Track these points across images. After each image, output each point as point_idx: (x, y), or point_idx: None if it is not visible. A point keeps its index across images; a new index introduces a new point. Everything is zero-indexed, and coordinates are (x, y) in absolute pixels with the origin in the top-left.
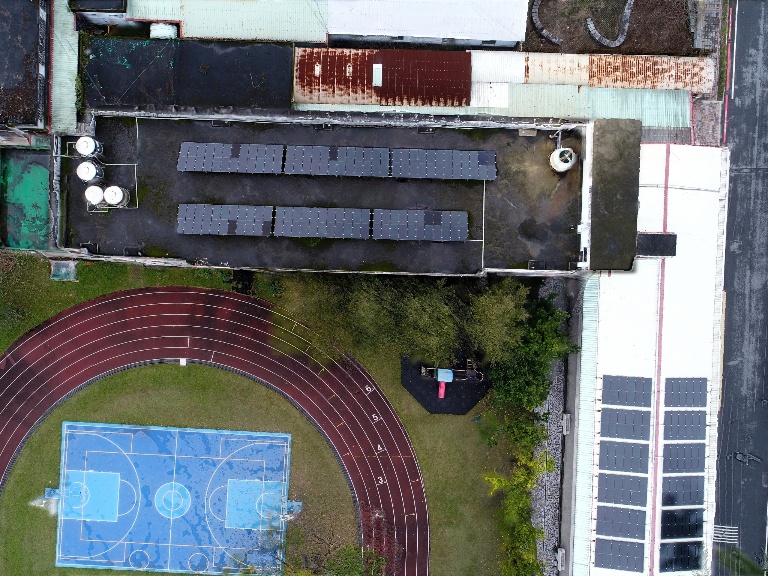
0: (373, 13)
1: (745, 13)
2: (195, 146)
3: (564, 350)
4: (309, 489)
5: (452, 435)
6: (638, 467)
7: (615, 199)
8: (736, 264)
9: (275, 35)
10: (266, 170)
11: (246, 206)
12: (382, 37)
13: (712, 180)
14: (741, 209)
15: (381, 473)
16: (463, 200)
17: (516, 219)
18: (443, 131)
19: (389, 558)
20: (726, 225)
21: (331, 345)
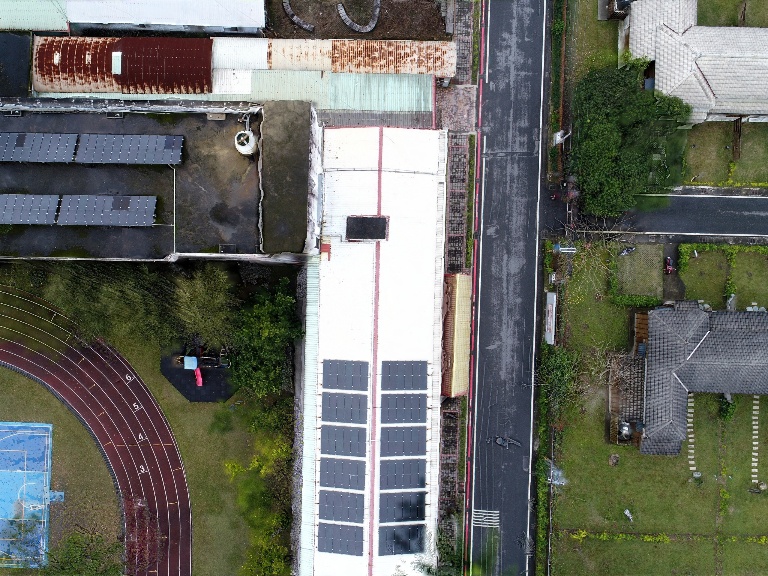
0: (110, 1)
1: None
2: None
3: (287, 335)
4: (71, 479)
5: (213, 423)
6: (356, 451)
7: (285, 181)
8: (493, 248)
9: (16, 24)
10: None
11: None
12: (123, 25)
13: (429, 163)
14: (497, 193)
15: (143, 462)
16: (154, 185)
17: (207, 203)
18: (133, 116)
19: (152, 547)
20: (445, 208)
21: (91, 334)
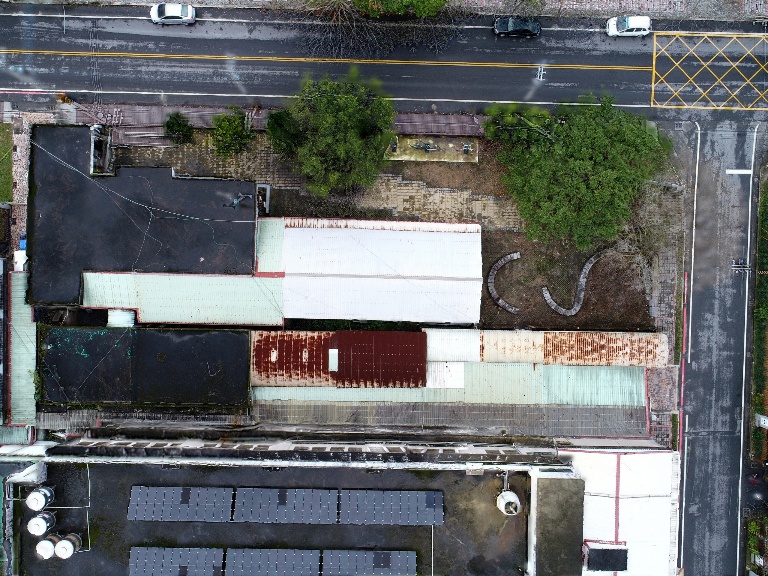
0: (328, 300)
1: (700, 278)
2: (145, 491)
3: None
4: None
5: None
6: None
7: (559, 558)
8: (695, 526)
9: (232, 319)
10: (215, 518)
11: (197, 549)
12: (338, 320)
13: (663, 485)
14: (699, 472)
15: None
16: (412, 538)
17: (465, 556)
18: (391, 470)
19: None
20: (678, 529)
21: None
